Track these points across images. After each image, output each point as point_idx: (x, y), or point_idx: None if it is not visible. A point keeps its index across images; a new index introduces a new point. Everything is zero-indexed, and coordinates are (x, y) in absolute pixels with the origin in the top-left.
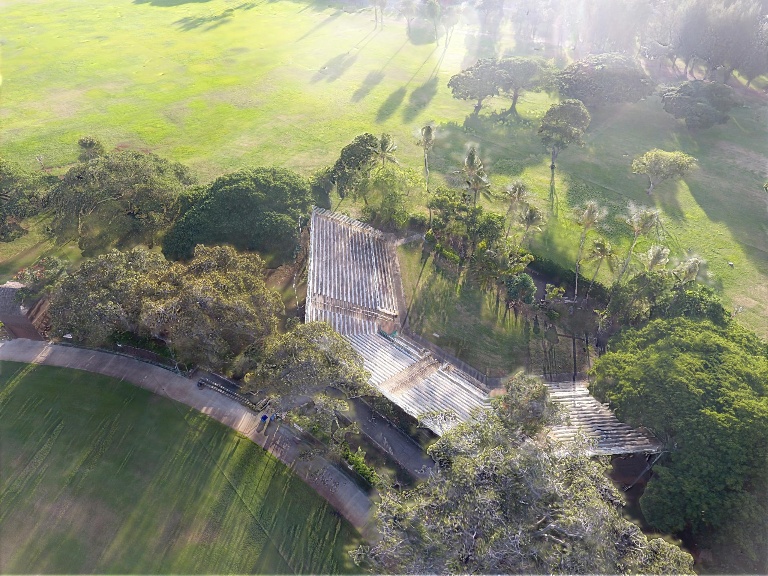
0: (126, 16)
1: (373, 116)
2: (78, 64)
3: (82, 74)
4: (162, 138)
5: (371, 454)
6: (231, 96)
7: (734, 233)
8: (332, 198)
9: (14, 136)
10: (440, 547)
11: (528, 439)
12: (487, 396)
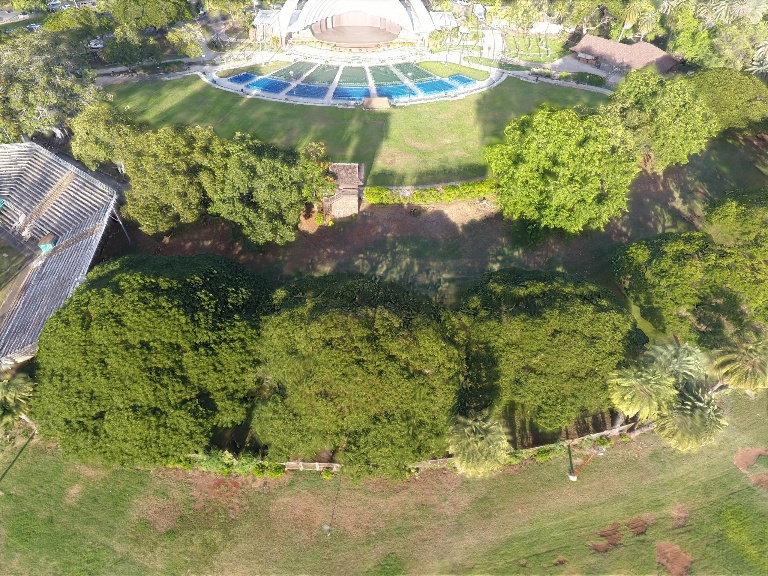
0: None
1: None
2: None
3: None
4: None
5: (100, 166)
6: None
7: None
8: (13, 490)
9: None
10: None
11: (1, 86)
12: (1, 199)
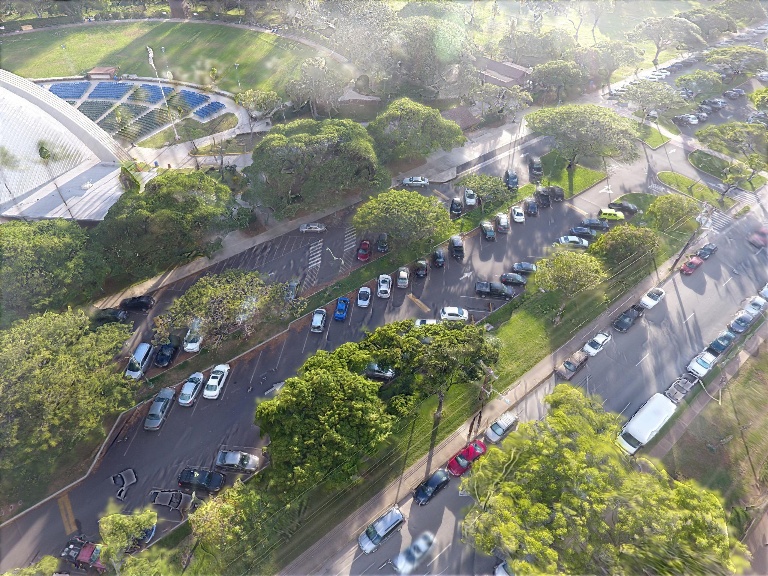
0: None
1: None
2: None
3: None
4: None
5: None
6: None
7: (504, 12)
8: None
9: None
10: (322, 5)
11: None
12: None
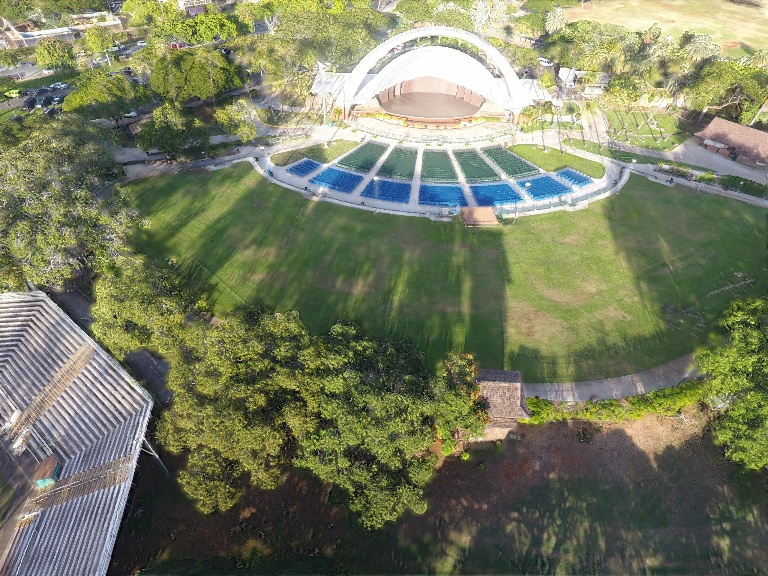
0: None
1: None
2: None
3: None
4: None
5: None
6: None
7: None
8: None
9: None
10: None
11: None
12: None
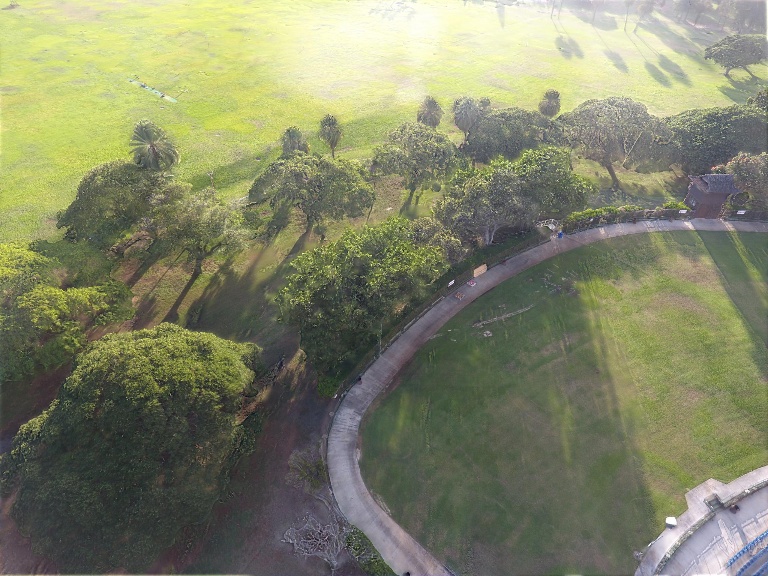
0: (316, 8)
1: (657, 83)
2: (346, 46)
3: (364, 54)
4: (515, 101)
5: None
6: (520, 70)
7: None
8: None
9: (396, 101)
10: None
11: None
12: None
